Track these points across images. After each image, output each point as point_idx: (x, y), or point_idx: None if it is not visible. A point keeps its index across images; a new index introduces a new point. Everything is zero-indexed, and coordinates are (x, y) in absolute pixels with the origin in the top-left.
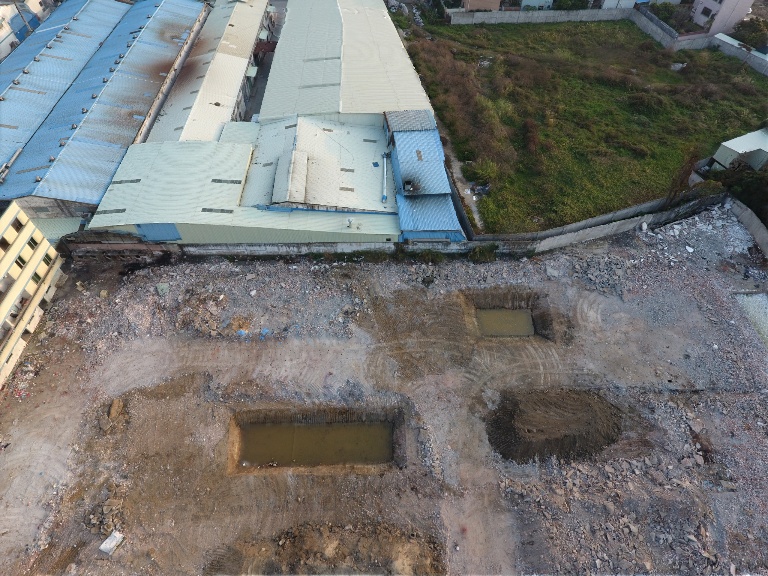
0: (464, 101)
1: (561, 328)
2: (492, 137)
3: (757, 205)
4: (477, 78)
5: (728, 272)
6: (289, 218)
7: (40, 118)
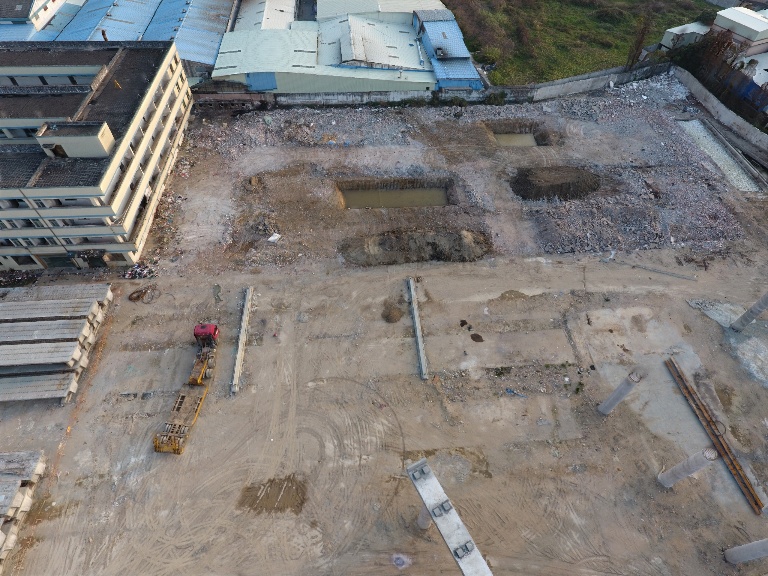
0: (469, 14)
1: (556, 138)
2: (495, 33)
3: (692, 69)
4: (477, 1)
5: (672, 109)
6: (356, 72)
7: (148, 18)
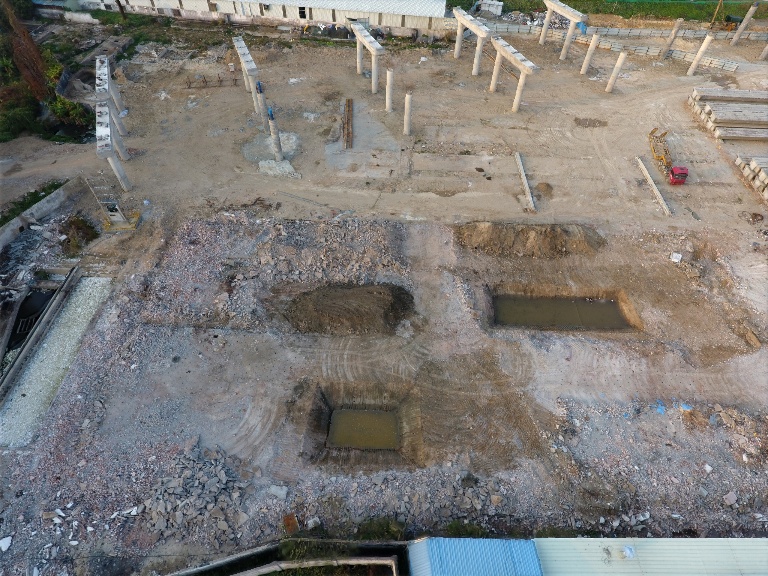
0: None
1: (303, 402)
2: None
3: None
4: None
5: None
6: (740, 570)
7: None
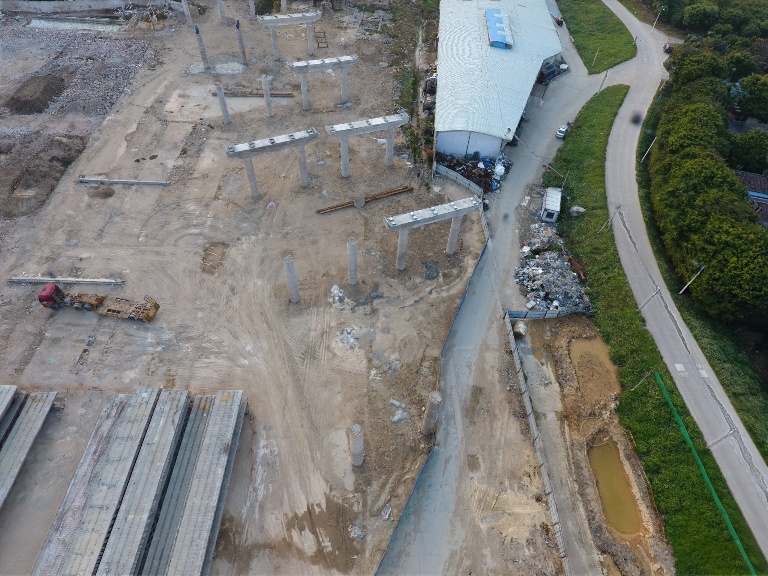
0: None
1: None
2: None
3: None
4: None
5: (9, 24)
6: None
7: None
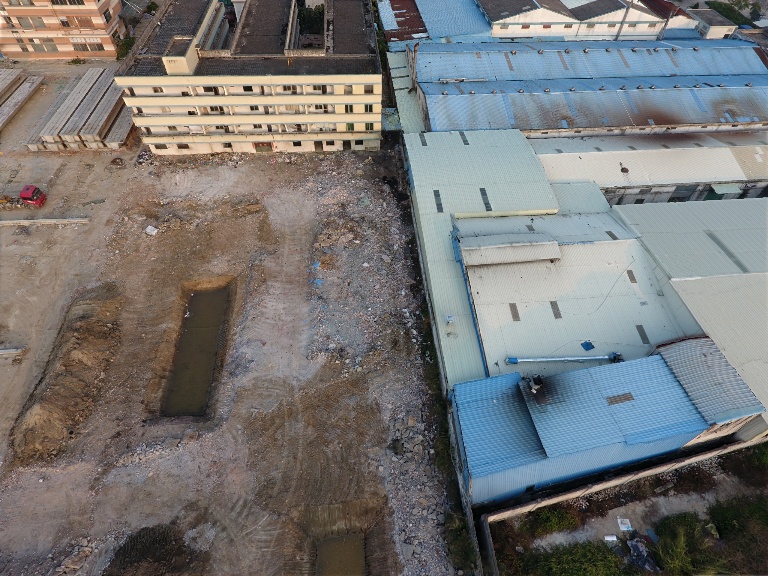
0: None
1: None
2: None
3: None
4: None
5: None
6: (446, 261)
7: (533, 77)
